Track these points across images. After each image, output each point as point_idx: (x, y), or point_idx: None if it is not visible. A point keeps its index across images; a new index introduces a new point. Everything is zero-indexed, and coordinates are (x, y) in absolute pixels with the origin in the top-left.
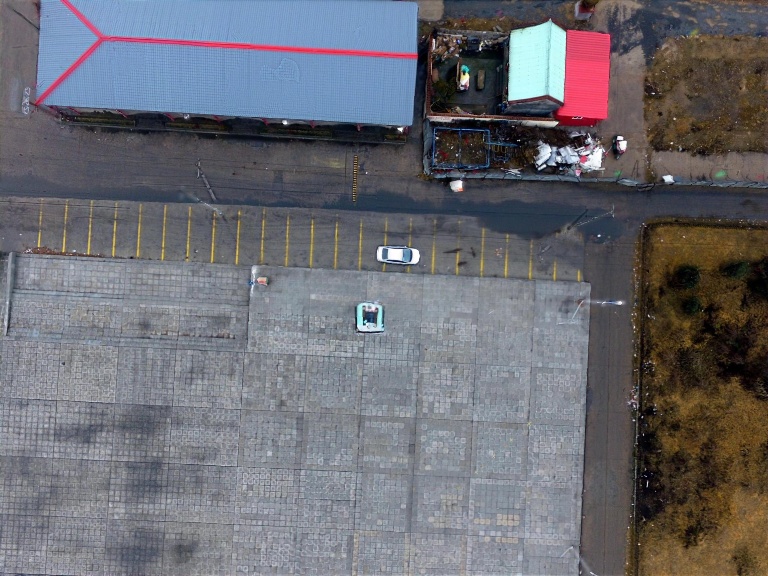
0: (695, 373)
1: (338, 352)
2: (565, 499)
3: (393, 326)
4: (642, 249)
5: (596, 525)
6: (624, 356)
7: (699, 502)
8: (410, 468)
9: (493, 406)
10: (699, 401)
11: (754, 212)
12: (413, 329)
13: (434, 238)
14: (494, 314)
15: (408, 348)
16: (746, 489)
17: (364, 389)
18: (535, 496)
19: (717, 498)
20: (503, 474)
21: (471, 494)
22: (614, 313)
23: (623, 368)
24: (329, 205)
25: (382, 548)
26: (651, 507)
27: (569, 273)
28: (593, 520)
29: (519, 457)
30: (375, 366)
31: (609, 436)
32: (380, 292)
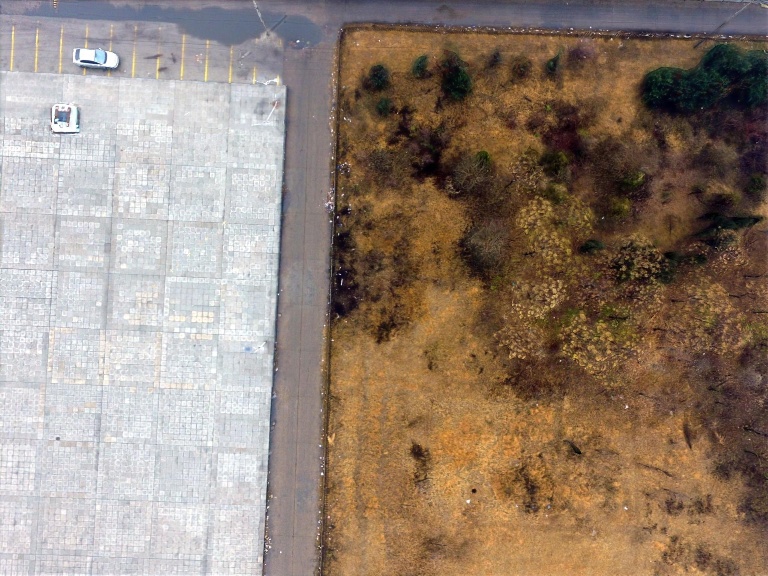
0: (389, 174)
1: (34, 153)
2: (259, 296)
3: (89, 127)
4: (339, 53)
5: (292, 323)
6: (322, 159)
7: (392, 299)
8: (106, 267)
9: (188, 206)
10: (393, 201)
11: (450, 17)
12: (109, 130)
13: (134, 44)
14: (190, 116)
15: (104, 149)
16: (437, 285)
17: (60, 189)
18: (229, 293)
19: (409, 294)
20: (198, 272)
21: (166, 292)
22: (312, 117)
23: (321, 171)
24: (30, 12)
25: (77, 345)
26: (345, 304)
27: (268, 78)
28: (290, 318)
29: (214, 255)
30: (71, 167)
31: (306, 237)
32: (76, 94)
